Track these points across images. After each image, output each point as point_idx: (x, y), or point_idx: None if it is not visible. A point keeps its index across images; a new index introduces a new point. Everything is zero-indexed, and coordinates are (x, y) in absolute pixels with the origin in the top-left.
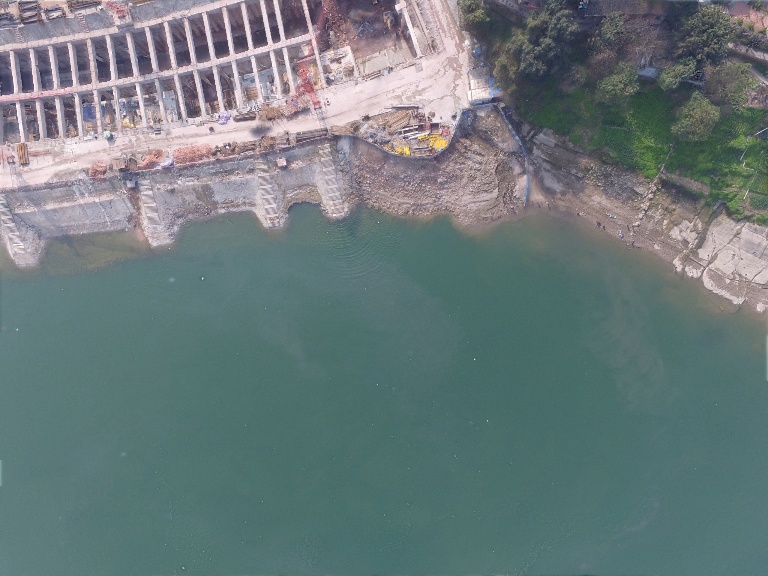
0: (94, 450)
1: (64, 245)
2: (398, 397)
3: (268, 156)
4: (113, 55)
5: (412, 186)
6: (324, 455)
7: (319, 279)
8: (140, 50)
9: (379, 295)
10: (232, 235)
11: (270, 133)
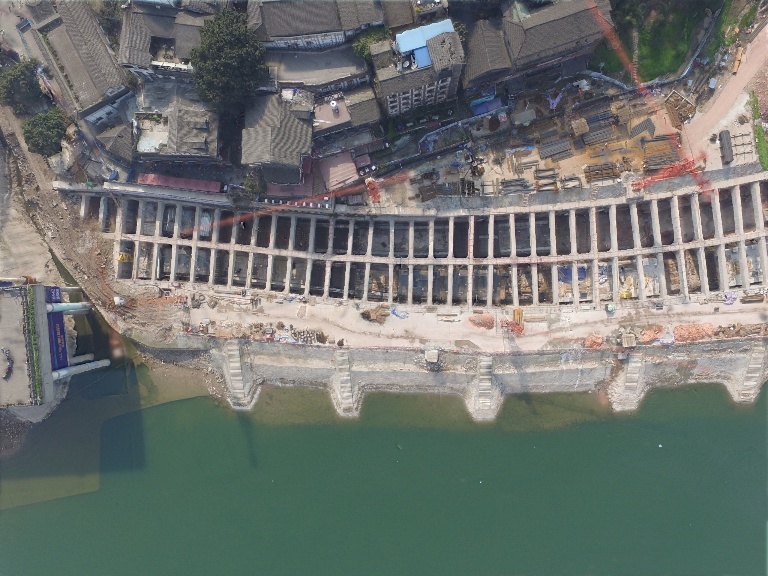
0: None
1: (522, 402)
2: None
3: None
4: (615, 224)
5: None
6: None
7: None
8: None
9: None
10: (696, 405)
11: None
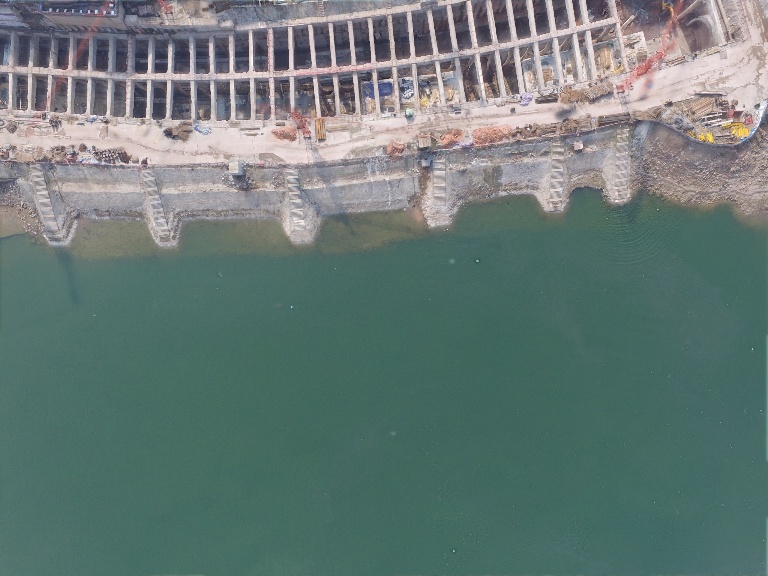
0: (364, 430)
1: (340, 223)
2: (673, 385)
3: (566, 139)
4: None
5: (703, 174)
6: (597, 441)
7: (595, 265)
8: (419, 29)
9: (658, 282)
10: (510, 218)
11: (572, 116)
